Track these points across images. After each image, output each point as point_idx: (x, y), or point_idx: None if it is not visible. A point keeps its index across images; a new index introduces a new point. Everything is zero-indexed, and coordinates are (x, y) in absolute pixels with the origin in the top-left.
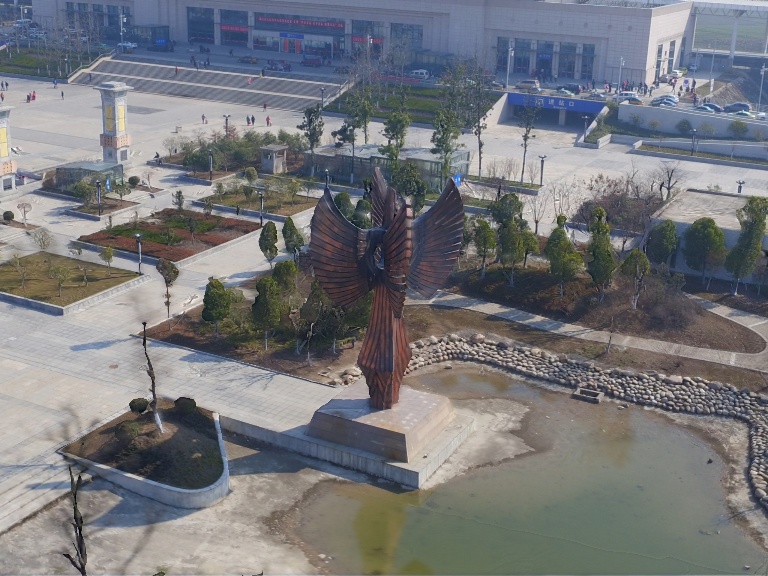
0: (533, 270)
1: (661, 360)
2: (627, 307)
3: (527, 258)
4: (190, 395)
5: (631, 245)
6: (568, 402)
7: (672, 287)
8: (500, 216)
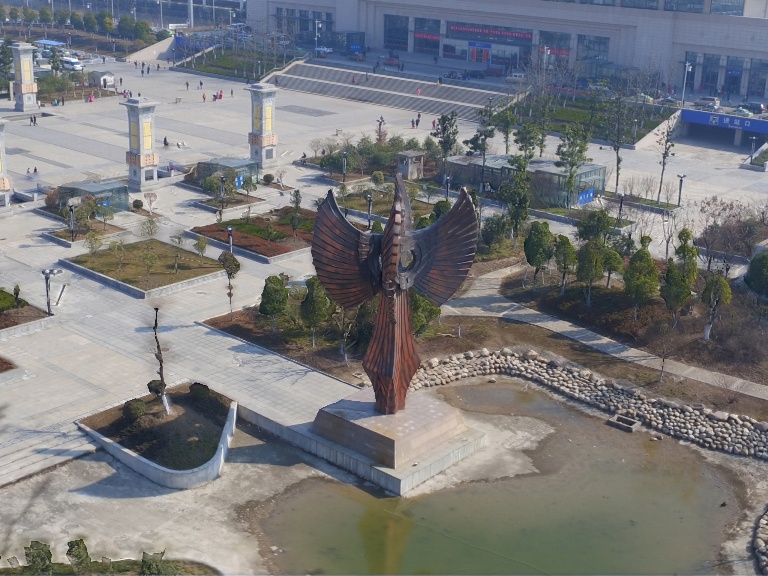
0: (615, 291)
1: (715, 394)
2: (700, 336)
3: (611, 278)
4: (220, 383)
5: (738, 273)
6: (600, 428)
7: (754, 319)
8: (587, 233)
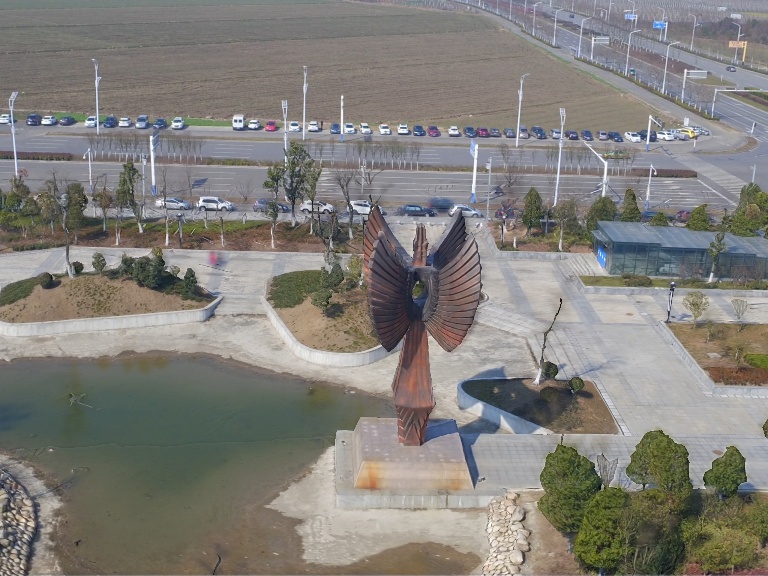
0: None
1: None
2: None
3: None
4: (603, 443)
5: None
6: None
7: None
8: None
